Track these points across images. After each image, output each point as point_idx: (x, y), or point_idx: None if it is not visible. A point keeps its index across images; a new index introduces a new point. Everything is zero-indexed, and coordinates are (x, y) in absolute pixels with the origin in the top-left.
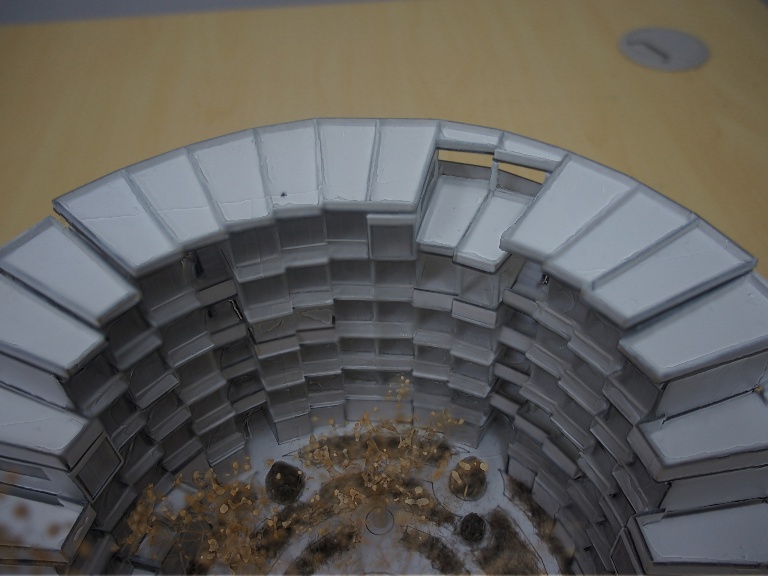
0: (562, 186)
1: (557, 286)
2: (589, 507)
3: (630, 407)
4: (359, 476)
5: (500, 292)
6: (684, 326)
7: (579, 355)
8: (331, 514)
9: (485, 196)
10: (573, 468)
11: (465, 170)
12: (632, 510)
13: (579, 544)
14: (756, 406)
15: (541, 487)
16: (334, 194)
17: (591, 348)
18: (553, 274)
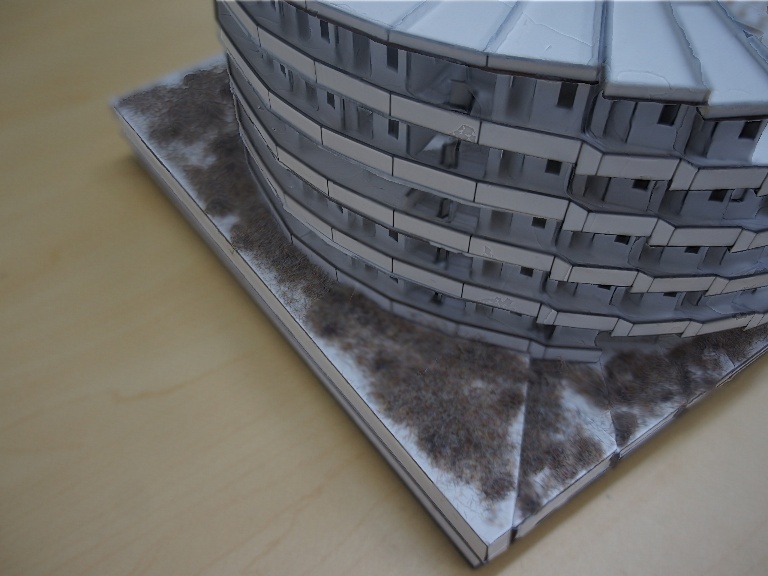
0: None
1: None
2: None
3: None
4: None
5: None
6: None
7: None
8: None
9: None
10: None
11: None
12: None
13: None
14: None
15: None
16: None
17: None
18: None
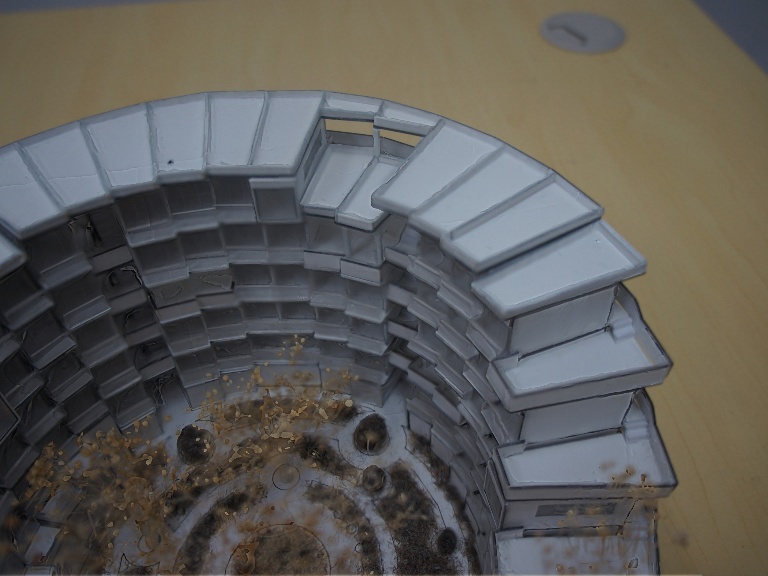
0: (434, 148)
1: (426, 240)
2: (471, 450)
3: (489, 347)
4: None
5: (383, 251)
6: (534, 270)
7: (447, 303)
8: (240, 472)
9: (370, 162)
10: (458, 415)
11: (354, 139)
12: (496, 443)
13: (469, 488)
14: (607, 343)
15: (436, 438)
16: (218, 160)
17: (455, 295)
18: (417, 227)
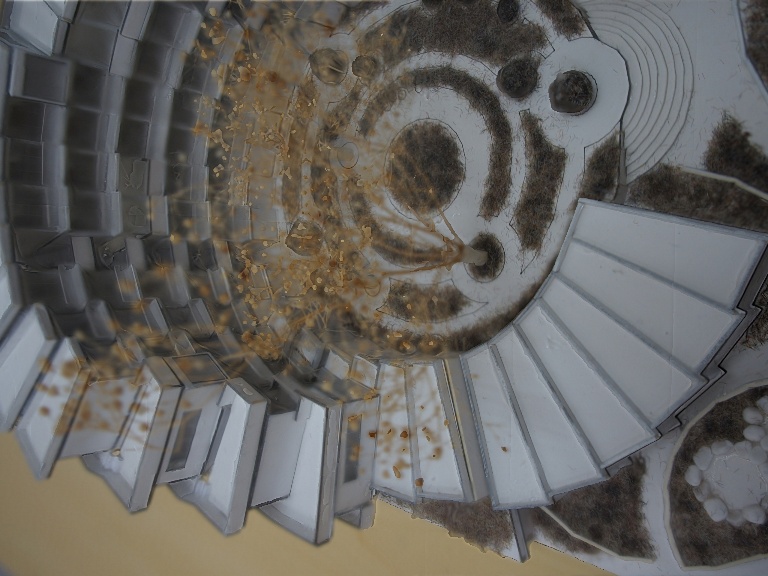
0: None
1: None
2: None
3: None
4: (312, 170)
5: None
6: None
7: None
8: (336, 199)
9: None
10: None
11: (10, 3)
12: None
13: None
14: None
15: None
16: None
17: None
18: None
